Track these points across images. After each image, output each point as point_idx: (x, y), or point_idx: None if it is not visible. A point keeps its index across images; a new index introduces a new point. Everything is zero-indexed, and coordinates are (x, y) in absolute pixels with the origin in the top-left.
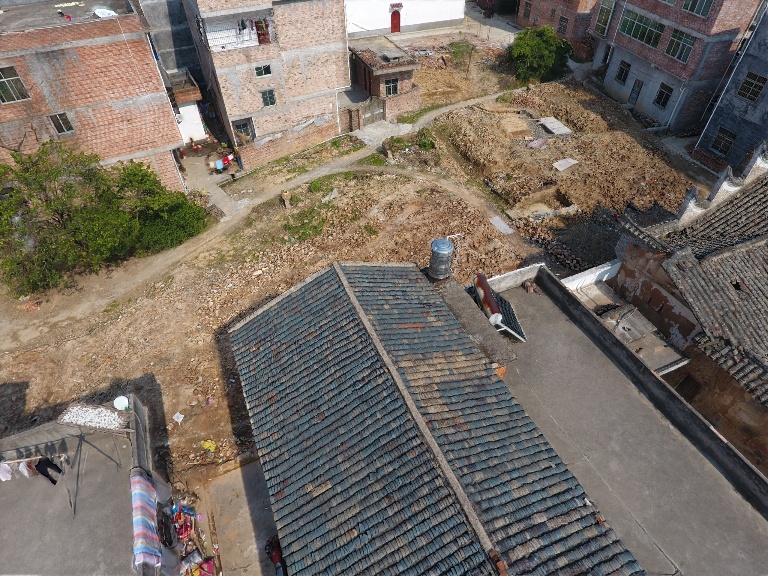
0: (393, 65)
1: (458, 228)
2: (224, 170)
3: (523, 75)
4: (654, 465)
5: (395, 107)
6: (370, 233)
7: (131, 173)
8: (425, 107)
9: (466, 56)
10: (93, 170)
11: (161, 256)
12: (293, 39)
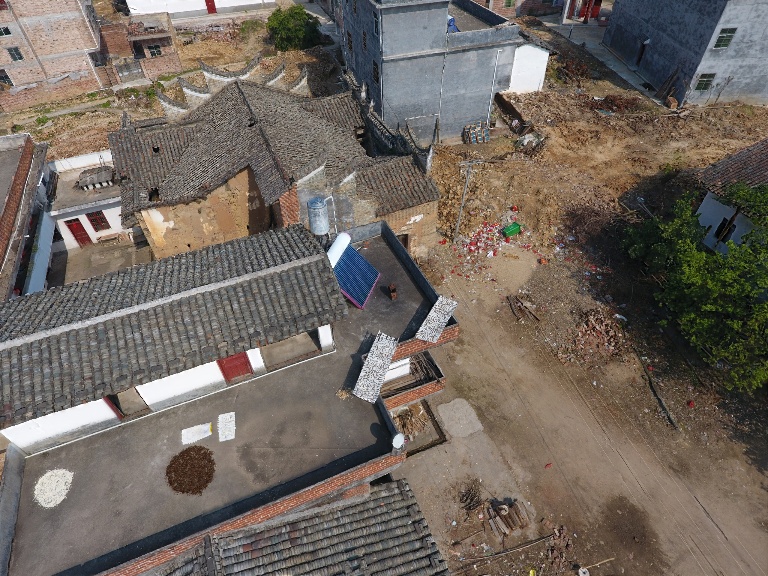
0: (145, 33)
1: None
2: None
3: (279, 45)
4: None
5: (154, 68)
6: None
7: None
8: (188, 69)
9: (251, 31)
10: None
11: None
12: (30, 8)
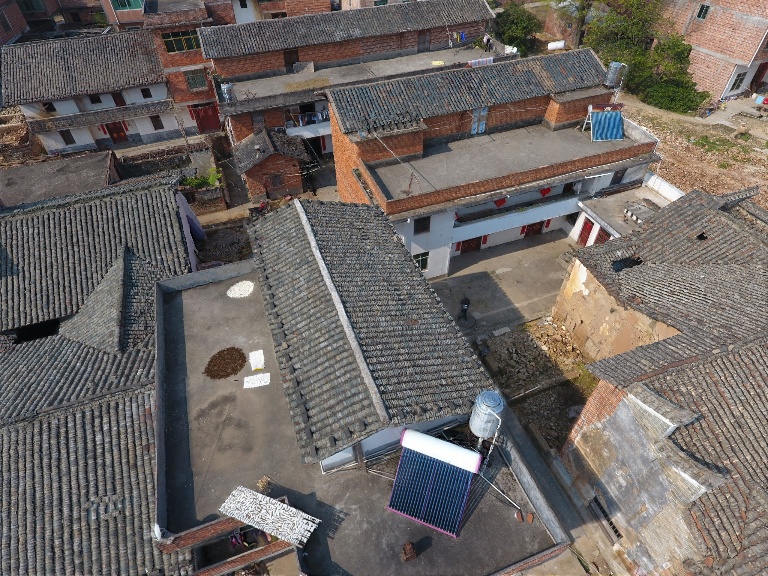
0: None
1: (765, 208)
2: (764, 111)
3: None
4: (525, 163)
5: None
6: (720, 165)
7: (672, 40)
8: None
9: None
10: (657, 24)
11: (644, 104)
12: None
